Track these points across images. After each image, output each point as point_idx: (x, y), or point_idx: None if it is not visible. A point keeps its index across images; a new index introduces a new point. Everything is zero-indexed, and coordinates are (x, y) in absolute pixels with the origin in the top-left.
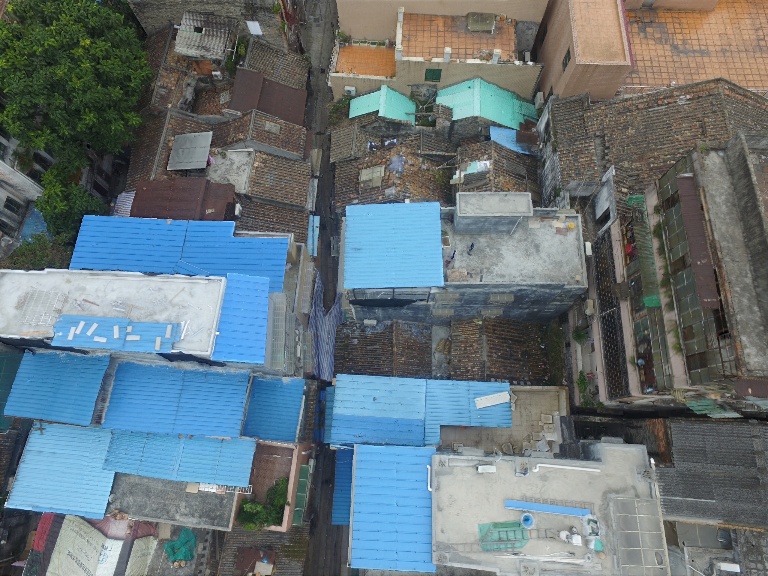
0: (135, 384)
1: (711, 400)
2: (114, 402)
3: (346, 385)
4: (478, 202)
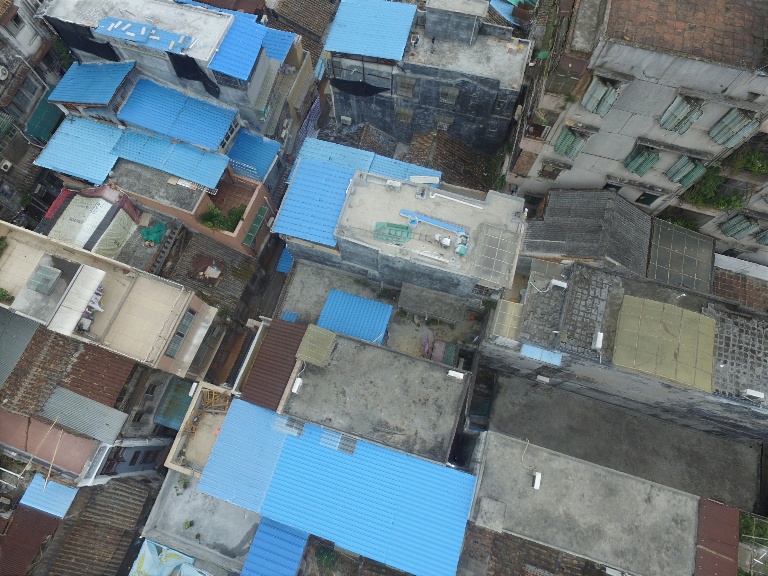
0: (149, 95)
1: (566, 128)
2: (130, 103)
3: (311, 146)
4: (445, 1)
